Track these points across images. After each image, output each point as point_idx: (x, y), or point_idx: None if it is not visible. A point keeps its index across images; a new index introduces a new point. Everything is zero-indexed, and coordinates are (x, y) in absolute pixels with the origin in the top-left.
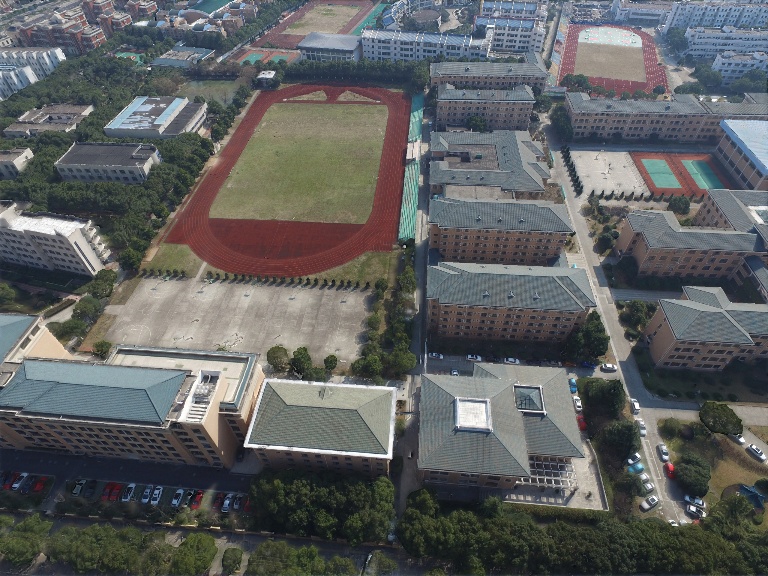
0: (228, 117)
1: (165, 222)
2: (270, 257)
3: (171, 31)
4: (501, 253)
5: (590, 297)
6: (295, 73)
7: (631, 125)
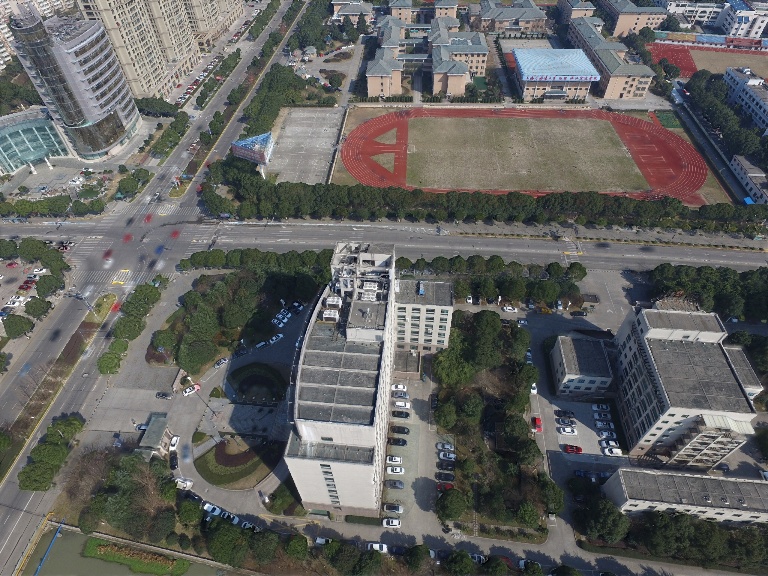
0: None
1: None
2: None
3: None
4: None
5: (395, 5)
6: None
7: None
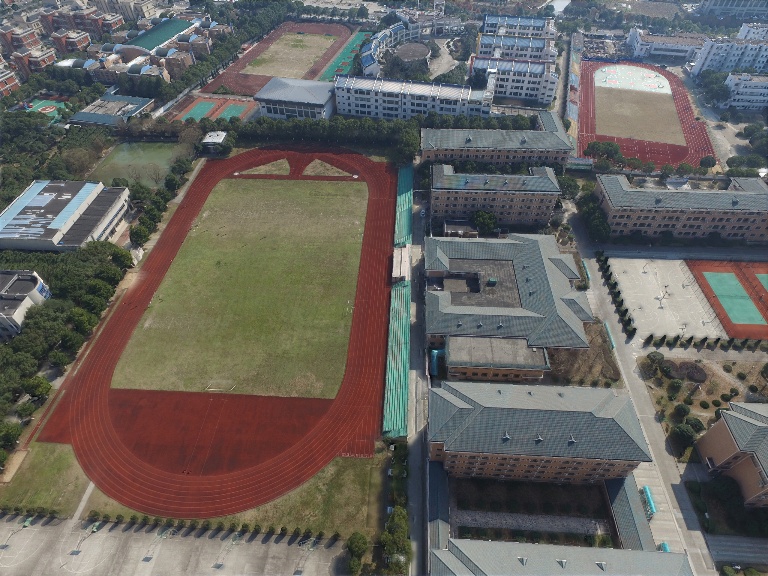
0: (156, 208)
1: (45, 398)
2: (192, 470)
3: (101, 73)
4: (537, 472)
5: None
6: (251, 133)
7: (686, 222)
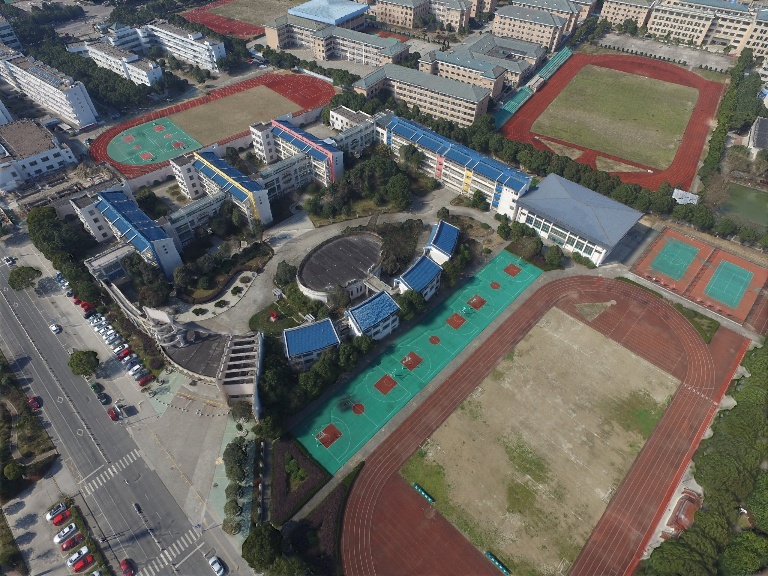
0: None
1: None
2: None
3: None
4: None
5: None
6: None
7: None
